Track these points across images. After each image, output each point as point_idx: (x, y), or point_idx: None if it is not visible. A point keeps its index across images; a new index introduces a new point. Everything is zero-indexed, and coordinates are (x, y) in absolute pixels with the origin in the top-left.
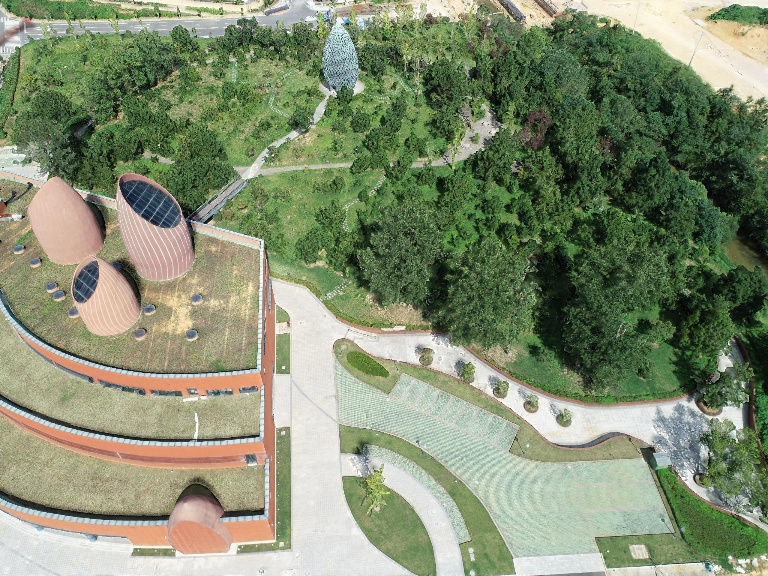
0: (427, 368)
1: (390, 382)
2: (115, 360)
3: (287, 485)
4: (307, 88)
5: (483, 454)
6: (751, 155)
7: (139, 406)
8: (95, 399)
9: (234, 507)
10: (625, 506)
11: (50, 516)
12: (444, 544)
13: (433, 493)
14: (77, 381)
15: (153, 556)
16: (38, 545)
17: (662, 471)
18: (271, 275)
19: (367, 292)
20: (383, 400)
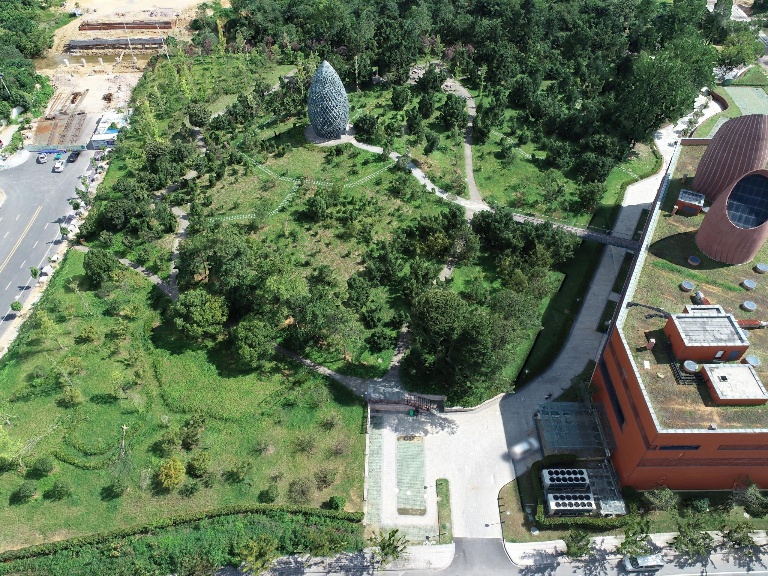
0: None
1: None
2: None
3: None
4: (333, 150)
5: None
6: None
7: None
8: None
9: None
10: None
11: None
12: None
13: None
14: None
15: None
16: None
17: (731, 82)
18: (621, 202)
19: (625, 158)
20: None
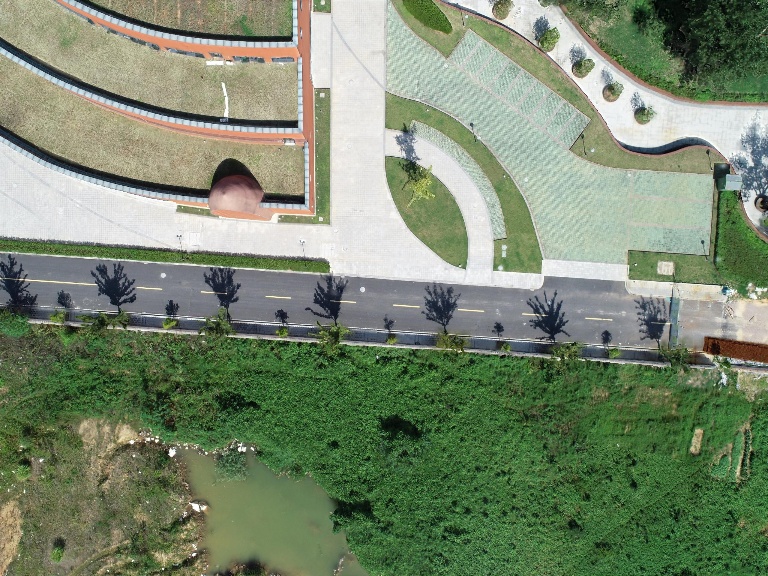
0: (500, 26)
1: (452, 41)
2: (114, 1)
3: (326, 158)
4: None
5: (541, 148)
6: None
7: (155, 65)
8: (101, 49)
9: (273, 189)
10: (671, 223)
11: (88, 180)
12: (479, 238)
13: (478, 186)
14: (73, 19)
15: (197, 215)
16: (83, 190)
17: (726, 193)
18: None
19: None
20: (440, 65)
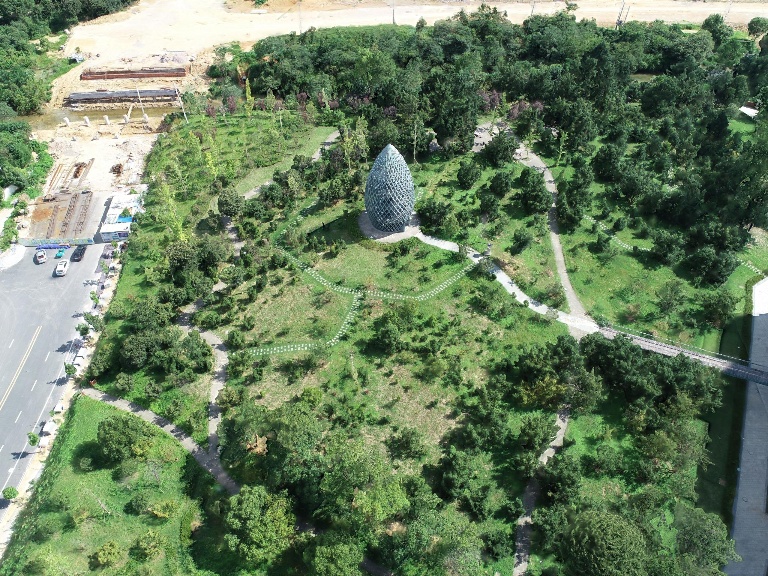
0: None
1: None
2: None
3: None
4: (398, 249)
5: None
6: (547, 31)
7: None
8: None
9: None
10: None
11: None
12: None
13: None
14: None
15: None
16: None
17: None
18: (751, 311)
19: None
20: None
